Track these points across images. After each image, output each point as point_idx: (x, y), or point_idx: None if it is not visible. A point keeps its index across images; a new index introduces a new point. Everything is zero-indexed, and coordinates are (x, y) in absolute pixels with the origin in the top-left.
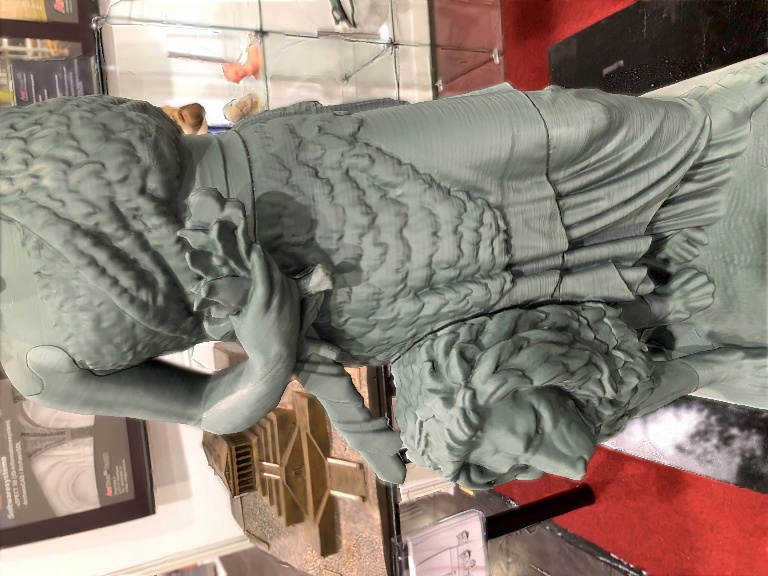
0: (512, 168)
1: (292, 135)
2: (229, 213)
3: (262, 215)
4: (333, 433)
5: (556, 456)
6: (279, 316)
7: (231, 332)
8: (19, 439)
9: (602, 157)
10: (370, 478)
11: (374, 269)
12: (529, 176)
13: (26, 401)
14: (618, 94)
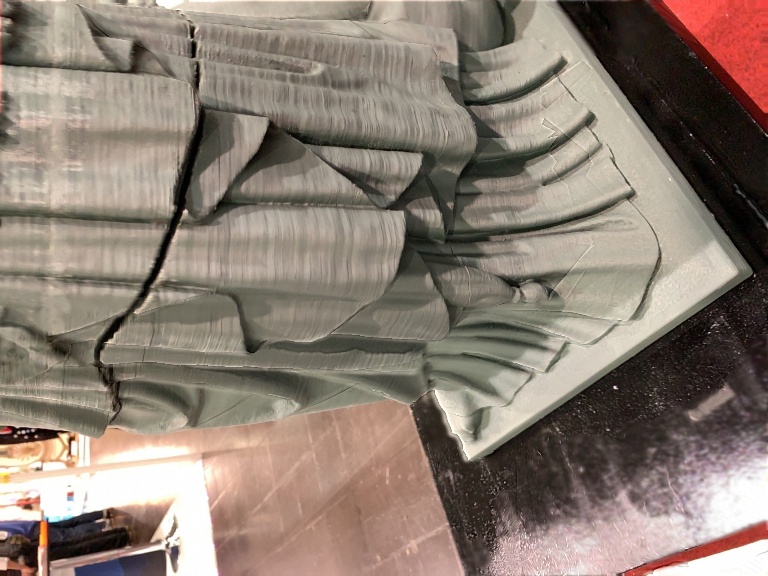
0: None
1: None
2: None
3: None
4: None
5: None
6: None
7: None
8: None
9: None
10: None
11: None
12: None
13: None
14: None
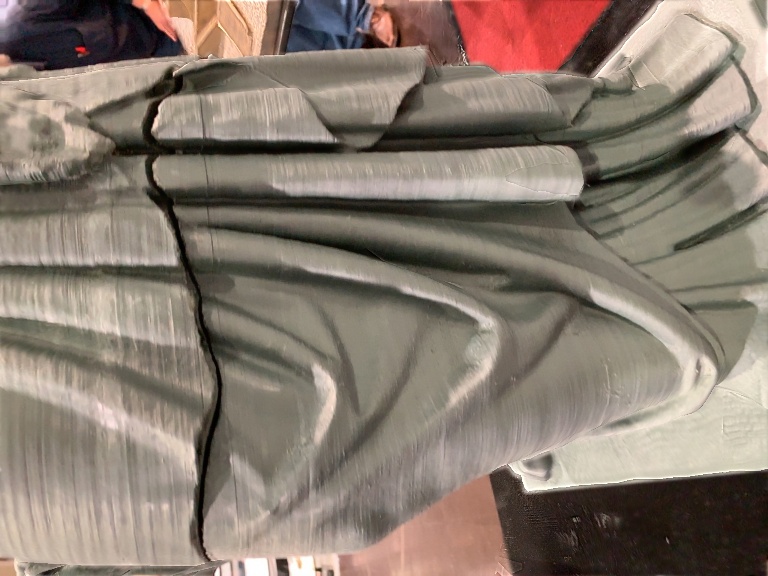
0: None
1: None
2: None
3: None
4: None
5: None
6: None
7: None
8: None
9: None
10: (255, 53)
11: None
12: None
13: None
14: (502, 428)
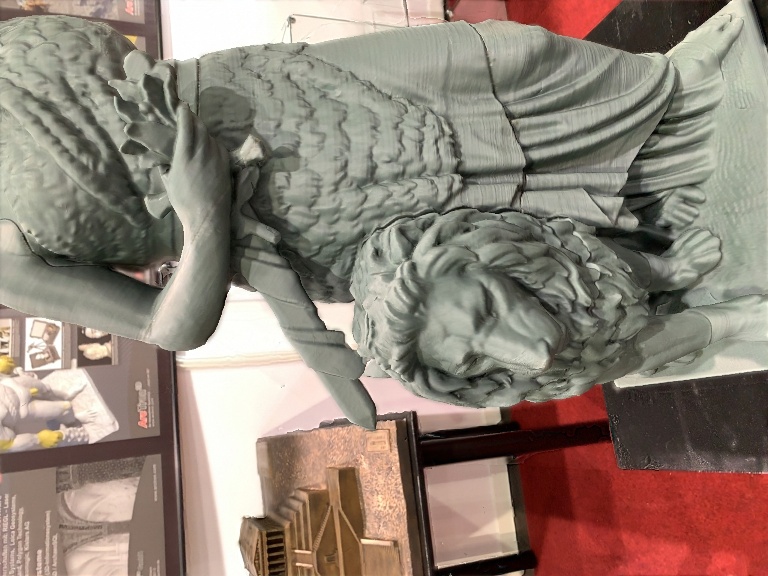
0: (453, 79)
1: (240, 51)
2: (158, 70)
3: (204, 105)
4: (366, 509)
5: (512, 337)
6: (204, 168)
7: (180, 230)
8: (57, 531)
9: (553, 83)
10: (405, 556)
11: (312, 155)
12: (474, 92)
13: (68, 491)
14: None
